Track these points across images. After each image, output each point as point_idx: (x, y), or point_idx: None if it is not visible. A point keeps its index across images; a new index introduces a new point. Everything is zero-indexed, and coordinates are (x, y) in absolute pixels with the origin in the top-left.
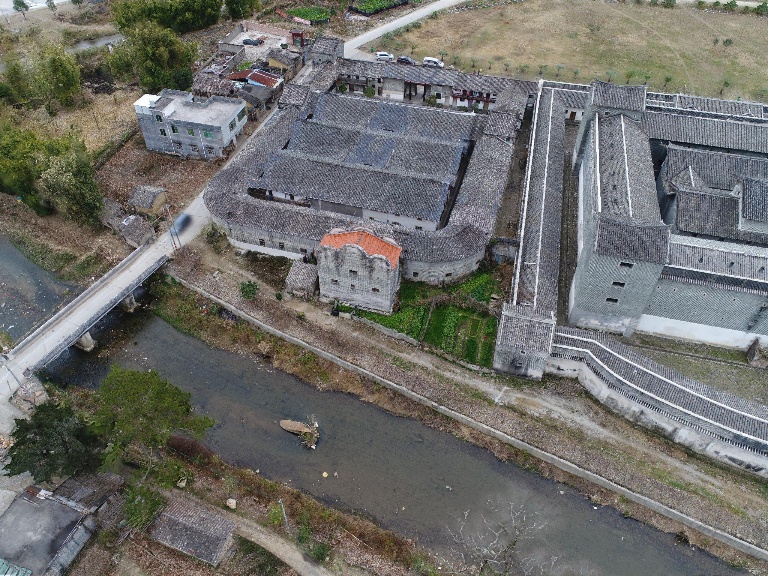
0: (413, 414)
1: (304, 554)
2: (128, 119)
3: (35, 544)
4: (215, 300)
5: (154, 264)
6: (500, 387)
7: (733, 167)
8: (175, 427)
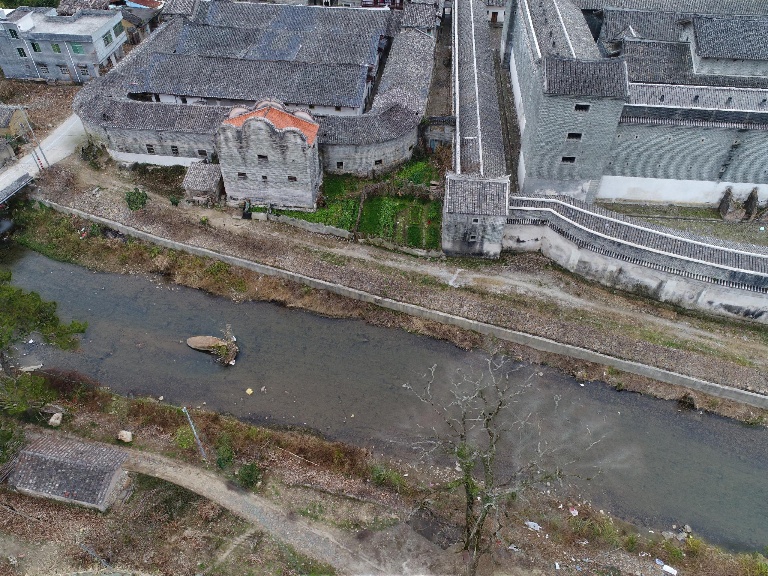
0: (353, 313)
1: (227, 482)
2: None
3: None
4: (96, 219)
5: (13, 184)
6: (453, 270)
7: None
8: (26, 330)
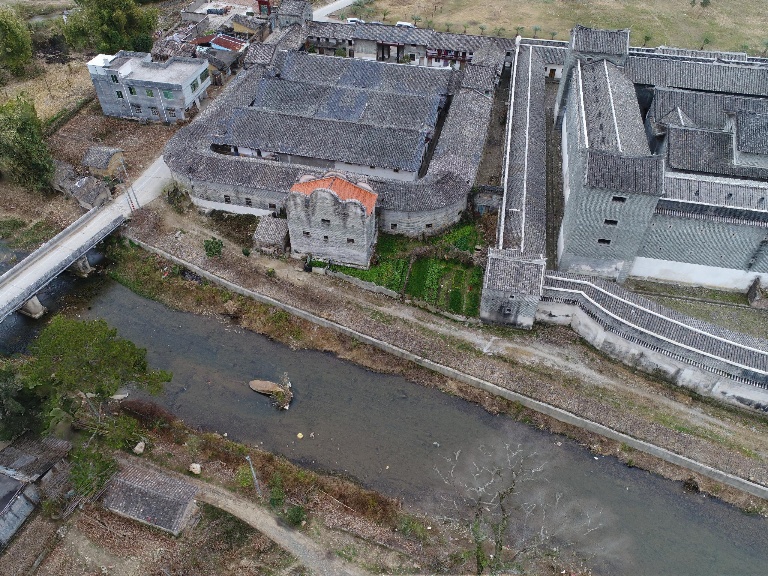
0: (395, 370)
1: (277, 519)
2: (84, 87)
3: None
4: (177, 261)
5: (109, 225)
6: (488, 337)
7: (723, 106)
8: (126, 380)
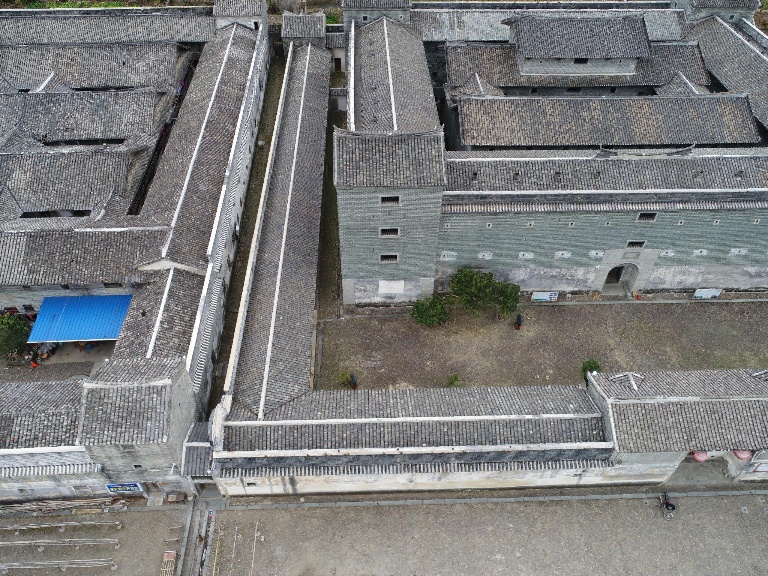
0: None
1: None
2: None
3: None
4: None
5: None
6: None
7: None
8: None
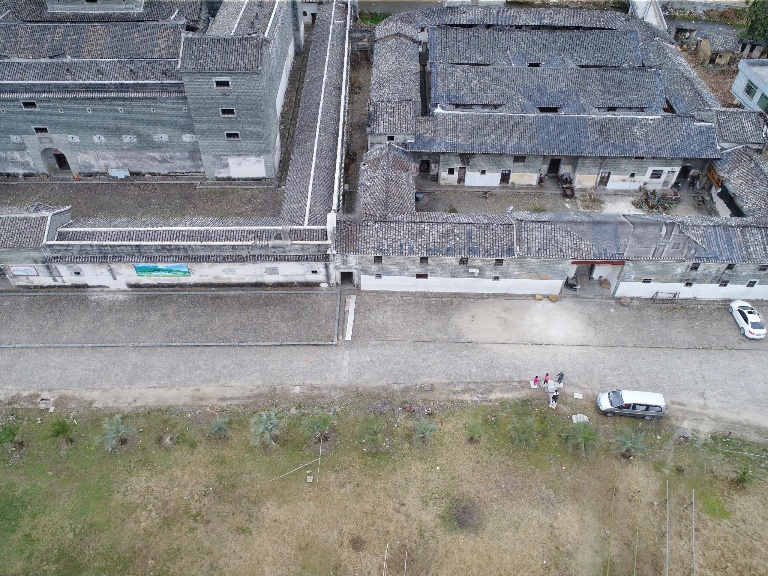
0: None
1: None
2: None
3: None
4: None
5: None
6: None
7: None
8: None
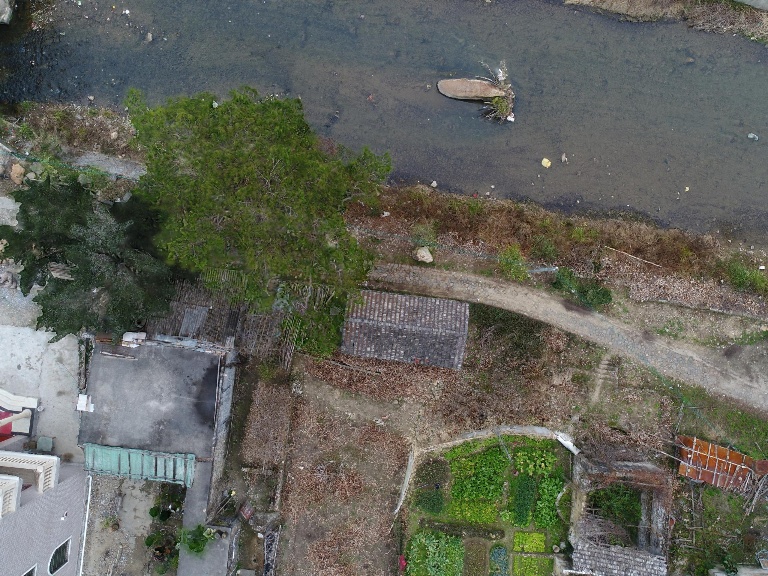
0: (669, 11)
1: (564, 302)
2: None
3: (172, 416)
4: None
5: None
6: None
7: None
8: None
